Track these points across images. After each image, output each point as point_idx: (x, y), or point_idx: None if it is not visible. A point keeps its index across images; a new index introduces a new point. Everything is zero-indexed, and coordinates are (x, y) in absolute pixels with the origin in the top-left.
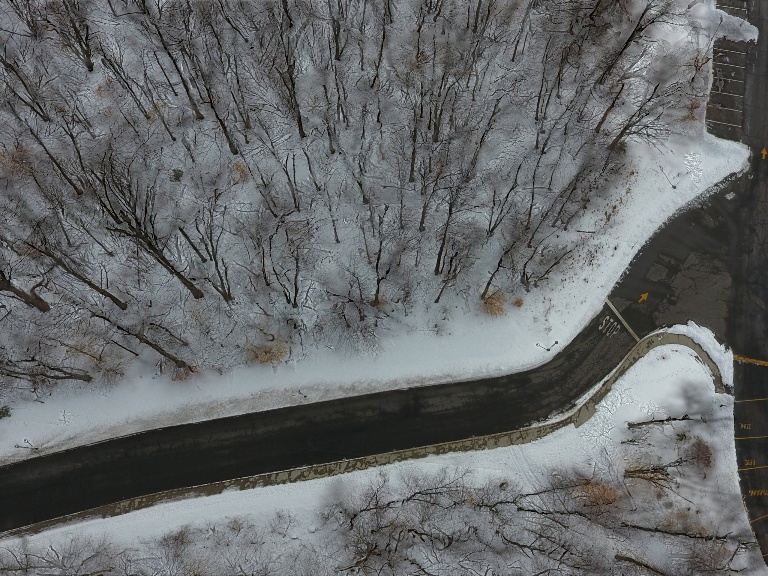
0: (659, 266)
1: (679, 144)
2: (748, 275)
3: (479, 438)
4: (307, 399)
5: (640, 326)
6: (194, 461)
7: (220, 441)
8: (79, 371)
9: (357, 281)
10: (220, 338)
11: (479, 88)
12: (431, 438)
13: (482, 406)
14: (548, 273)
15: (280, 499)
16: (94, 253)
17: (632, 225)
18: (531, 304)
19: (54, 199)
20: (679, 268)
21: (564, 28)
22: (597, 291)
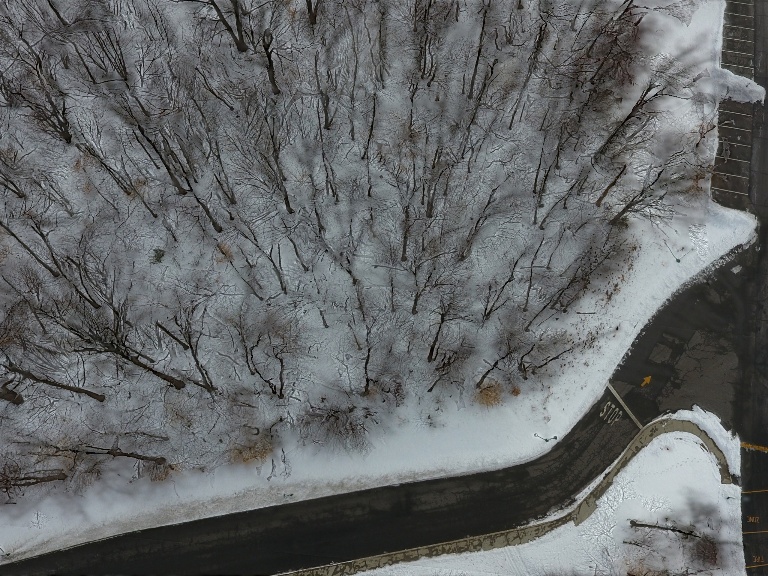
0: (663, 346)
1: None
2: (755, 355)
3: (474, 538)
4: (293, 497)
5: (643, 412)
6: (174, 566)
7: (202, 544)
8: (53, 471)
9: (346, 370)
10: (202, 432)
11: (475, 159)
12: (424, 539)
13: (477, 503)
14: (547, 359)
15: None
16: (70, 340)
17: (634, 303)
18: (529, 392)
19: (29, 282)
20: (683, 348)
21: (563, 94)
22: (598, 375)
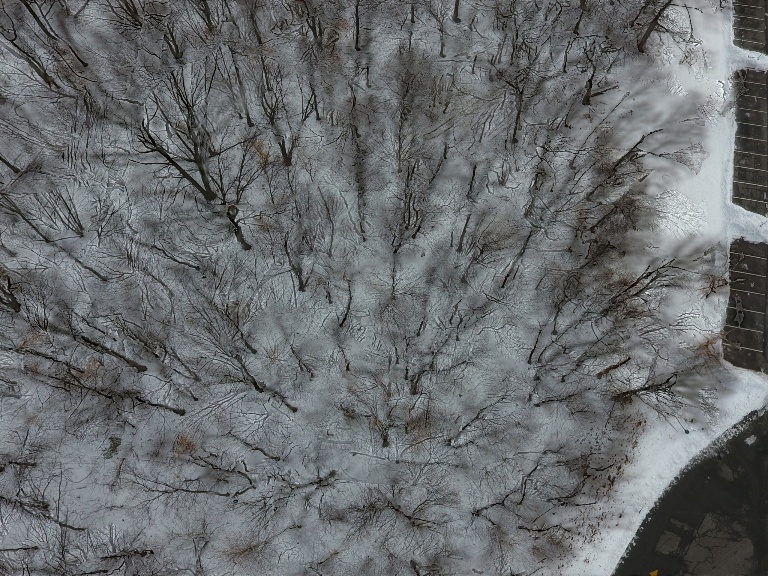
0: (670, 534)
1: (692, 379)
2: None
3: None
4: None
5: None
6: None
7: None
8: None
9: None
10: None
11: (464, 325)
12: None
13: None
14: (543, 560)
15: None
16: None
17: (639, 484)
18: None
19: None
20: (693, 535)
21: (561, 247)
22: (599, 571)
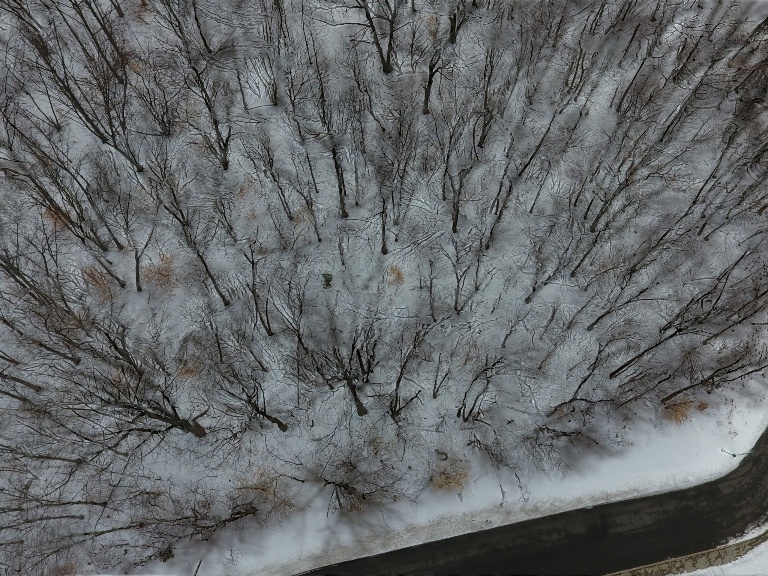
0: None
1: None
2: None
3: (675, 560)
4: (488, 524)
5: None
6: None
7: (400, 575)
8: None
9: (529, 390)
10: (390, 459)
11: None
12: (624, 562)
13: (673, 523)
14: None
15: None
16: (248, 370)
17: None
18: (713, 407)
19: (201, 312)
20: None
21: (711, 104)
22: None
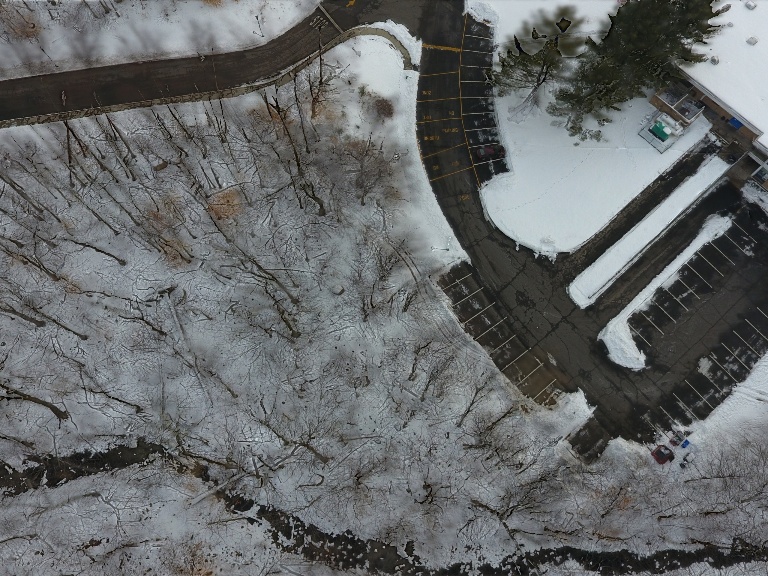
0: None
1: None
2: None
3: (196, 94)
4: (58, 68)
5: (345, 23)
6: None
7: None
8: None
9: None
10: None
11: None
12: (157, 95)
13: (202, 74)
14: None
15: (29, 134)
16: None
17: None
18: None
19: None
20: None
21: None
22: None
